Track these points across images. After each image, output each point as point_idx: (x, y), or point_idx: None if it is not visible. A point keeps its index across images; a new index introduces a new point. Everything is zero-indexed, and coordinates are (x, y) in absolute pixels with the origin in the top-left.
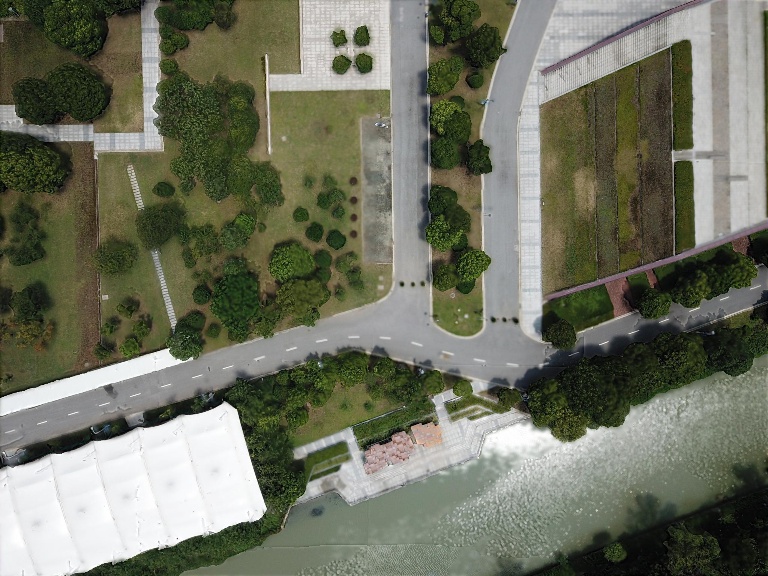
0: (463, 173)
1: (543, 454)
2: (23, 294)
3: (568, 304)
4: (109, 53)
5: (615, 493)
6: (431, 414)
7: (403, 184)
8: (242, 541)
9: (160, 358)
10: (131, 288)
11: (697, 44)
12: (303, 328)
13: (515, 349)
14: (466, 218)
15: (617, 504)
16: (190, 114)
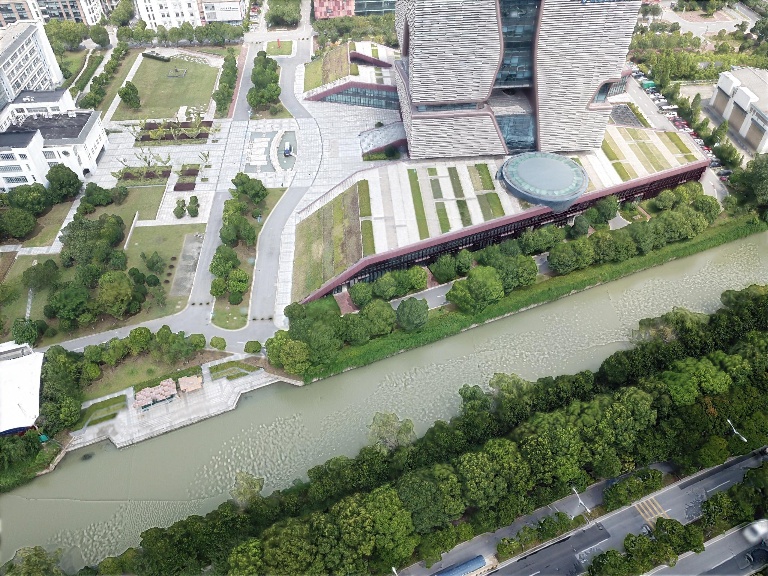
0: (244, 252)
1: (292, 414)
2: None
3: (307, 307)
4: (48, 218)
5: (349, 434)
6: (198, 374)
7: (206, 260)
8: (11, 474)
9: (4, 346)
10: (4, 315)
11: (372, 181)
12: (117, 331)
13: (269, 335)
14: (233, 254)
15: (350, 440)
16: None
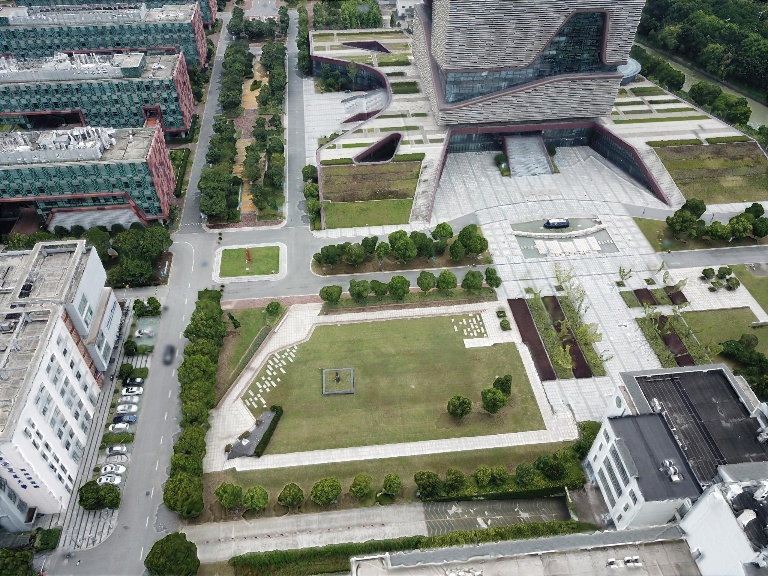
0: None
1: None
2: None
3: None
4: None
5: None
6: None
7: None
8: None
9: None
10: None
11: None
12: None
13: None
14: None
15: None
16: None
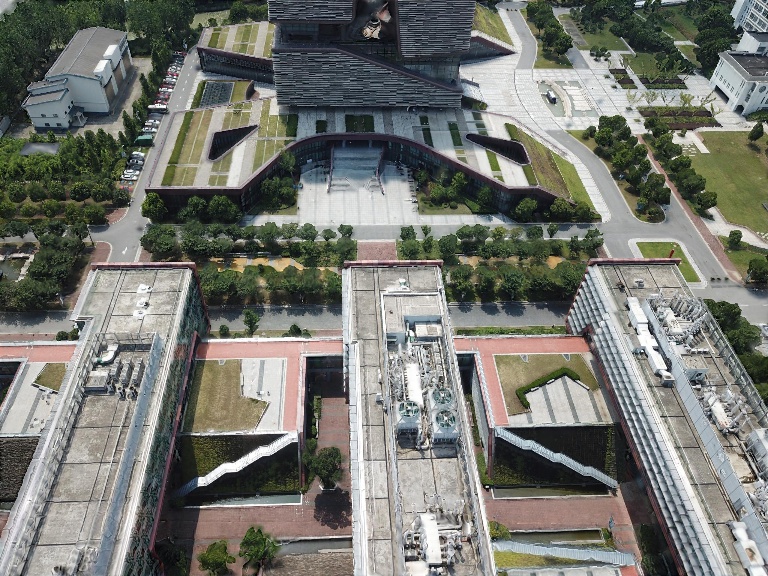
0: None
1: None
2: (693, 4)
3: None
4: None
5: None
6: None
7: None
8: None
9: (636, 4)
10: None
11: None
12: None
13: (505, 6)
14: None
15: None
16: None
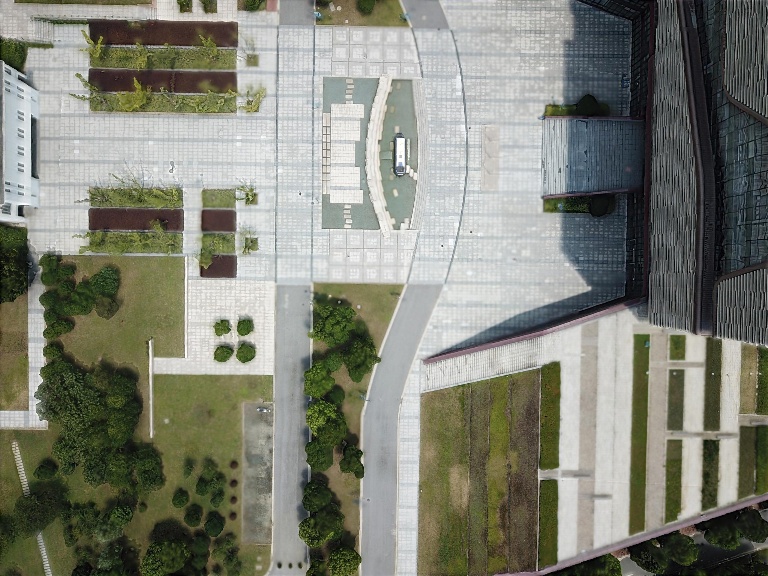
0: None
1: None
2: None
3: None
4: None
5: None
6: None
7: (284, 467)
8: None
9: None
10: (13, 563)
11: (566, 365)
12: None
13: None
14: (336, 524)
15: None
16: (71, 403)
